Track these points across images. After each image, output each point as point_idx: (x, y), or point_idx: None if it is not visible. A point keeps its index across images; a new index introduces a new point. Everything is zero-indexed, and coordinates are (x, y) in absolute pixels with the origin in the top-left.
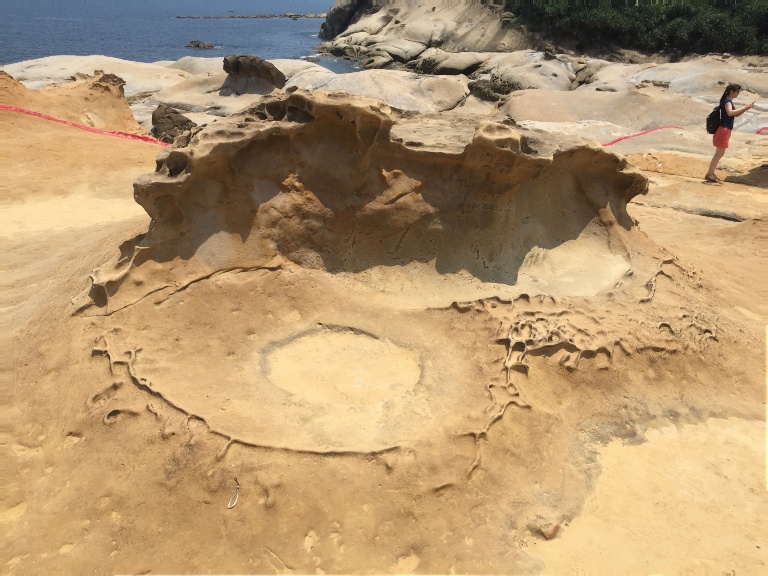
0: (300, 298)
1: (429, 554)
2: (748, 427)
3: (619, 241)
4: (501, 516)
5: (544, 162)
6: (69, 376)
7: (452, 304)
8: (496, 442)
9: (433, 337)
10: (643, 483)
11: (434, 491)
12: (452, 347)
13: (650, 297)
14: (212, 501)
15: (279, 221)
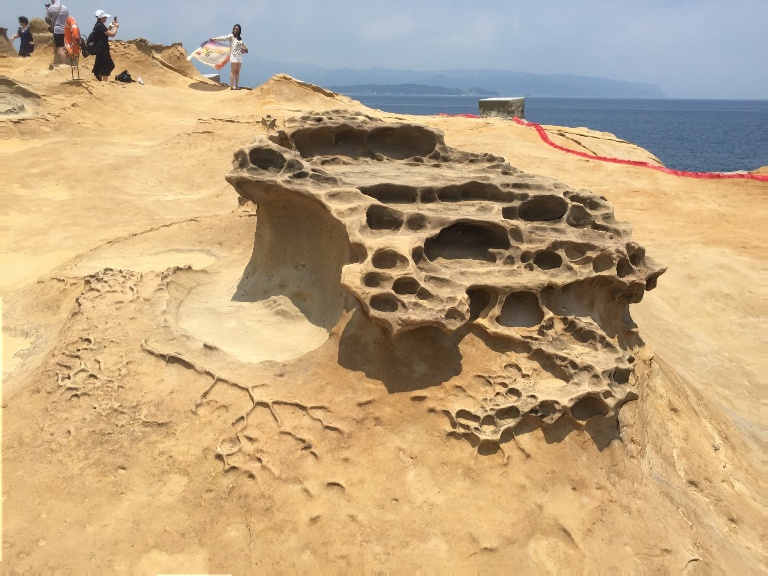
0: None
1: None
2: None
3: None
4: None
5: None
6: None
7: None
8: None
9: None
10: None
11: None
12: None
13: (146, 347)
14: None
15: None
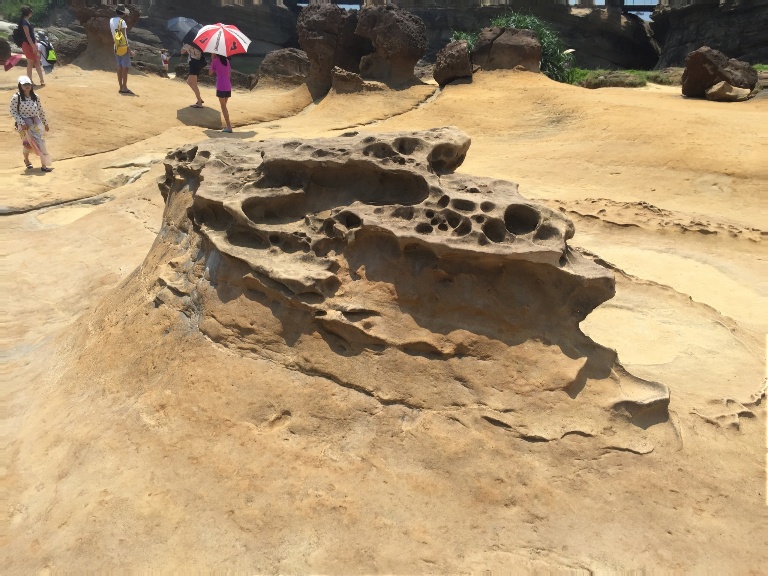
0: None
1: None
2: None
3: None
4: None
5: None
6: (764, 453)
7: None
8: None
9: None
10: None
11: None
12: None
13: None
14: None
15: None
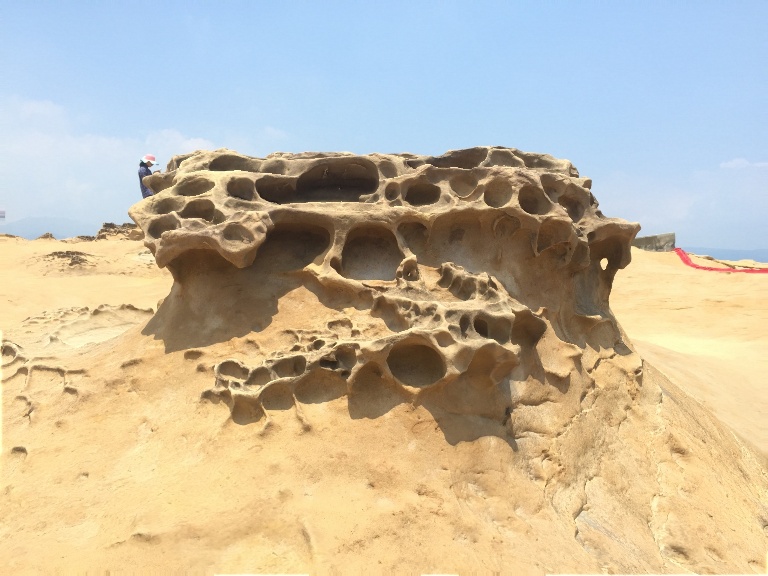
0: None
1: None
2: None
3: None
4: None
5: None
6: None
7: None
8: None
9: None
10: None
11: None
12: None
13: None
14: None
15: None
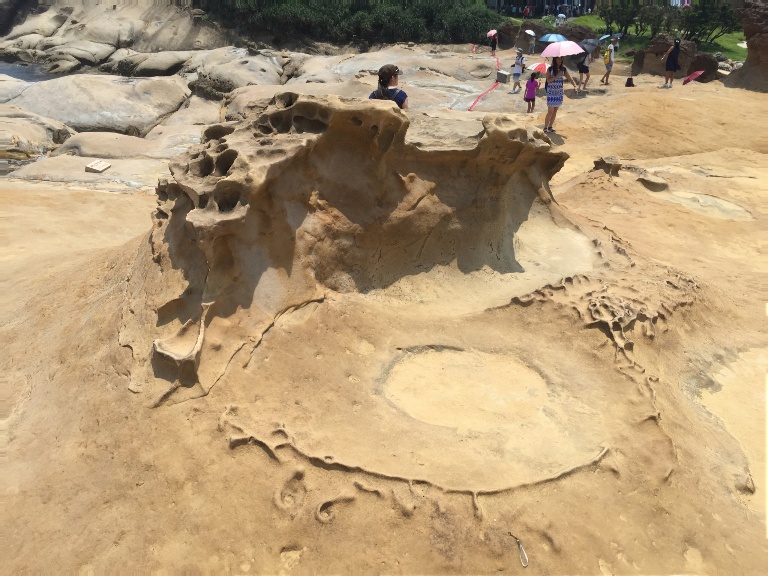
0: (361, 326)
1: (702, 541)
2: (767, 354)
3: (561, 216)
4: (716, 485)
5: (545, 149)
6: None
7: (512, 300)
8: (666, 419)
9: (516, 336)
10: (755, 421)
11: (665, 481)
12: (544, 341)
13: None
14: (505, 566)
15: (314, 246)
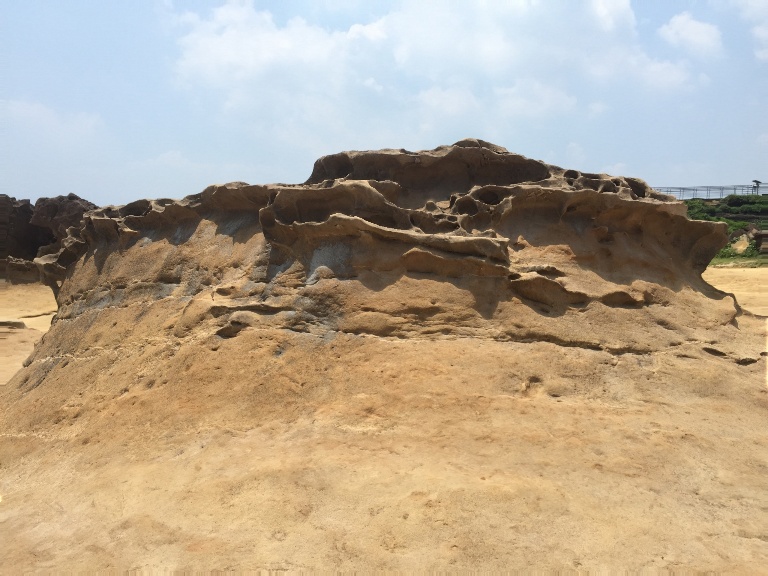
0: None
1: None
2: None
3: None
4: None
5: None
6: None
7: None
8: None
9: None
10: None
11: None
12: None
13: None
14: None
15: None
